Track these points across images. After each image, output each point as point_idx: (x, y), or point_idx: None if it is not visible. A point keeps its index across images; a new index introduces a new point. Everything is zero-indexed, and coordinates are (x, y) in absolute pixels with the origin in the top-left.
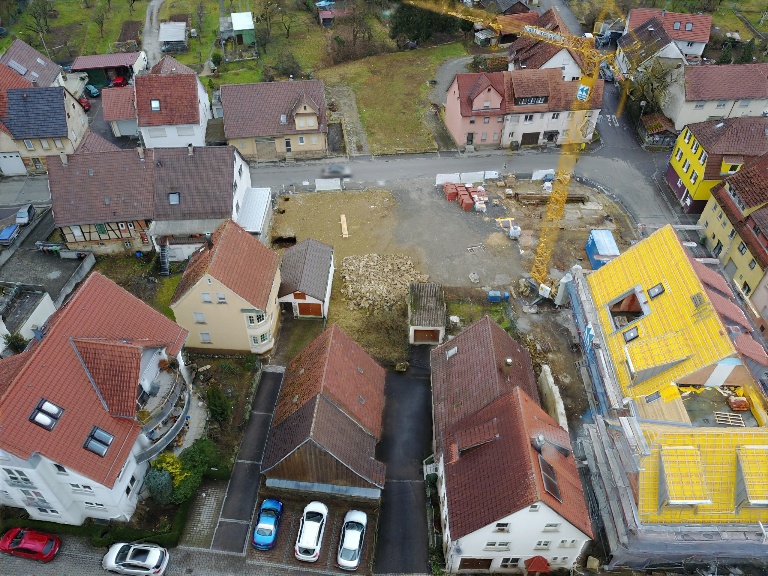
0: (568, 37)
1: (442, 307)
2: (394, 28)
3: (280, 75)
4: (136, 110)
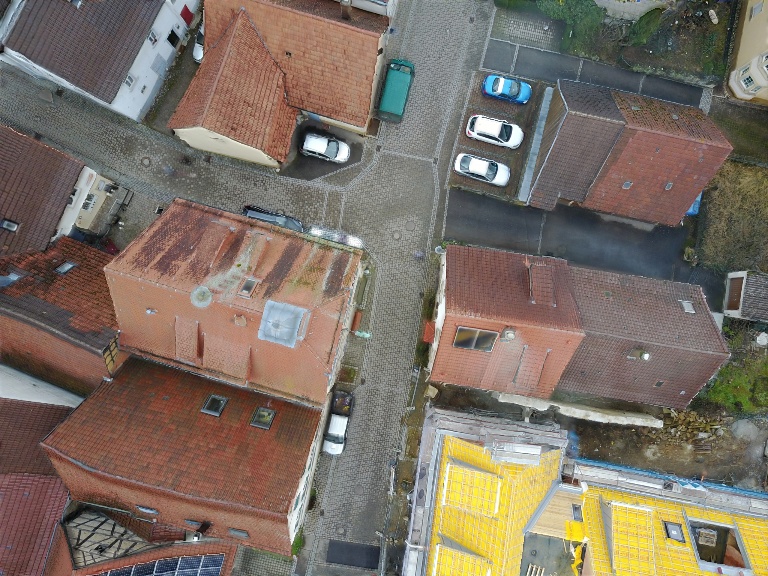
0: None
1: None
2: None
3: None
4: None
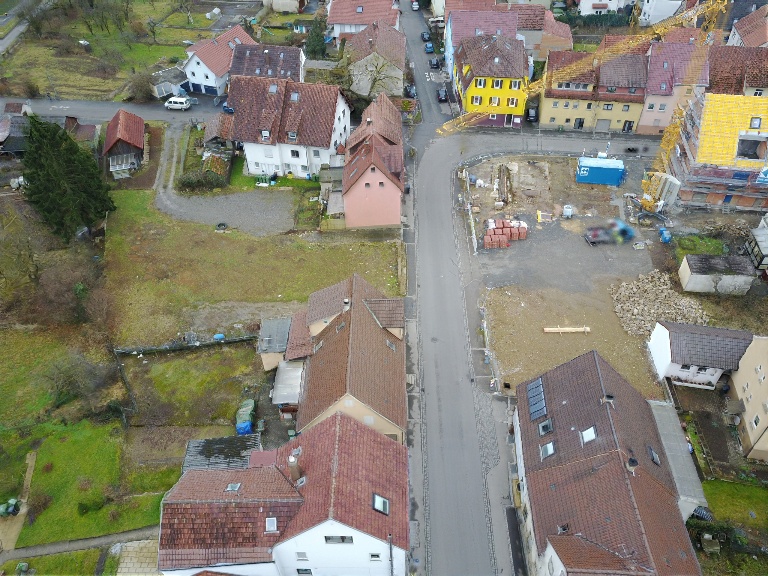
0: (703, 4)
1: (723, 256)
2: (56, 231)
3: (94, 396)
4: (388, 543)
